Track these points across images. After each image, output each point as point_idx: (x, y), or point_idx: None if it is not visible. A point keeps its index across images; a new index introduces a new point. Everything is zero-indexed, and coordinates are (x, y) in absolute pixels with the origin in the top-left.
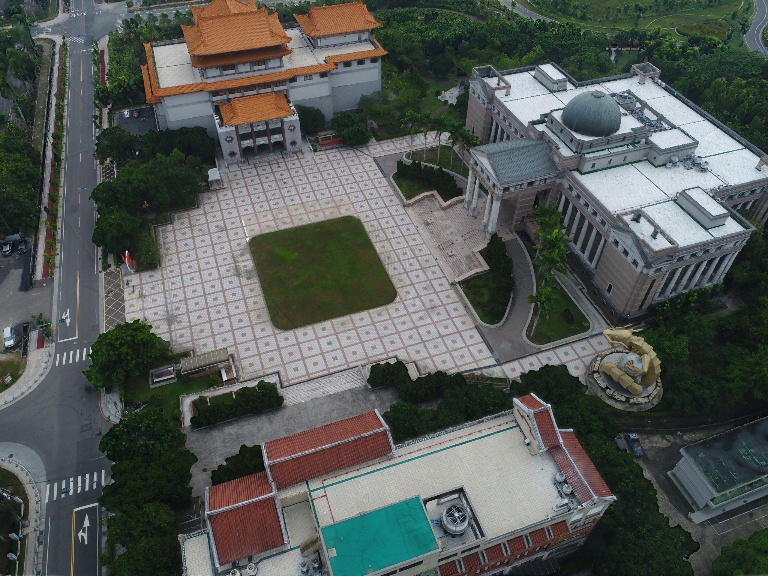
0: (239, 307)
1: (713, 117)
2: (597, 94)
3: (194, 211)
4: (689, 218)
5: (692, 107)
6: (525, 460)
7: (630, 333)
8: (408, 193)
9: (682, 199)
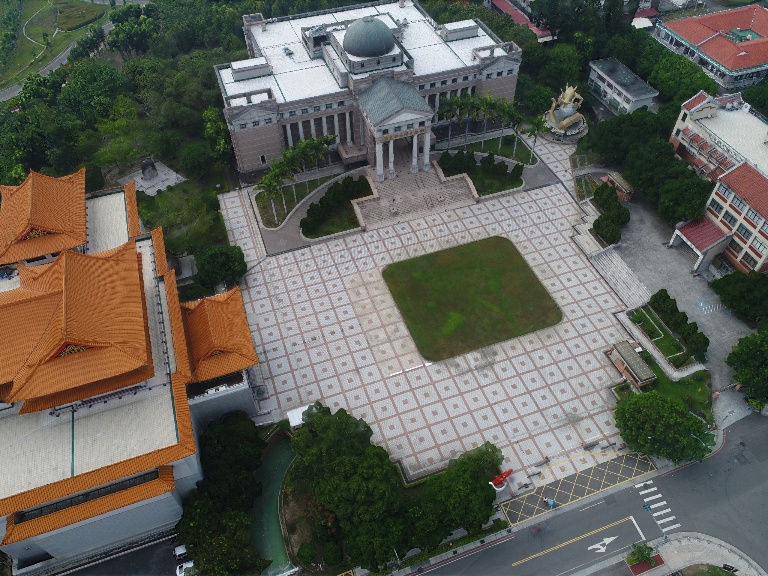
0: (541, 356)
1: (332, 9)
2: (370, 19)
3: (372, 437)
4: (466, 40)
5: (313, 15)
6: (721, 119)
7: (569, 90)
8: (345, 226)
9: (452, 35)
